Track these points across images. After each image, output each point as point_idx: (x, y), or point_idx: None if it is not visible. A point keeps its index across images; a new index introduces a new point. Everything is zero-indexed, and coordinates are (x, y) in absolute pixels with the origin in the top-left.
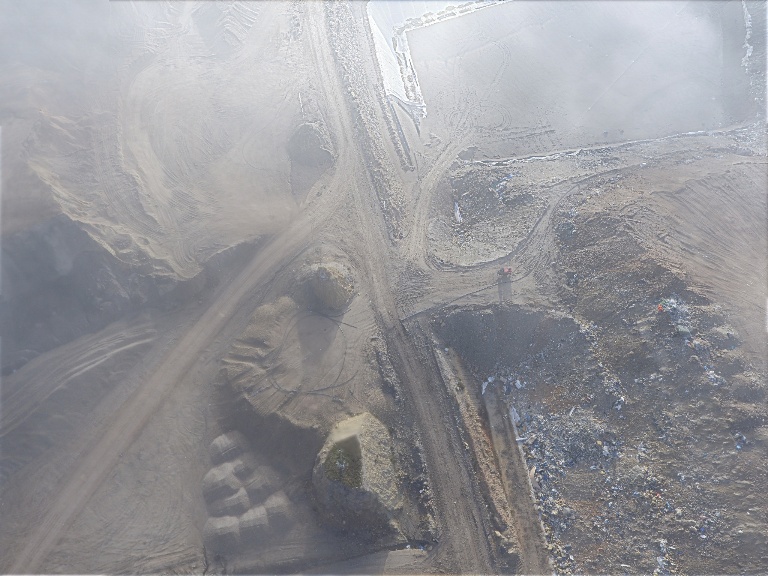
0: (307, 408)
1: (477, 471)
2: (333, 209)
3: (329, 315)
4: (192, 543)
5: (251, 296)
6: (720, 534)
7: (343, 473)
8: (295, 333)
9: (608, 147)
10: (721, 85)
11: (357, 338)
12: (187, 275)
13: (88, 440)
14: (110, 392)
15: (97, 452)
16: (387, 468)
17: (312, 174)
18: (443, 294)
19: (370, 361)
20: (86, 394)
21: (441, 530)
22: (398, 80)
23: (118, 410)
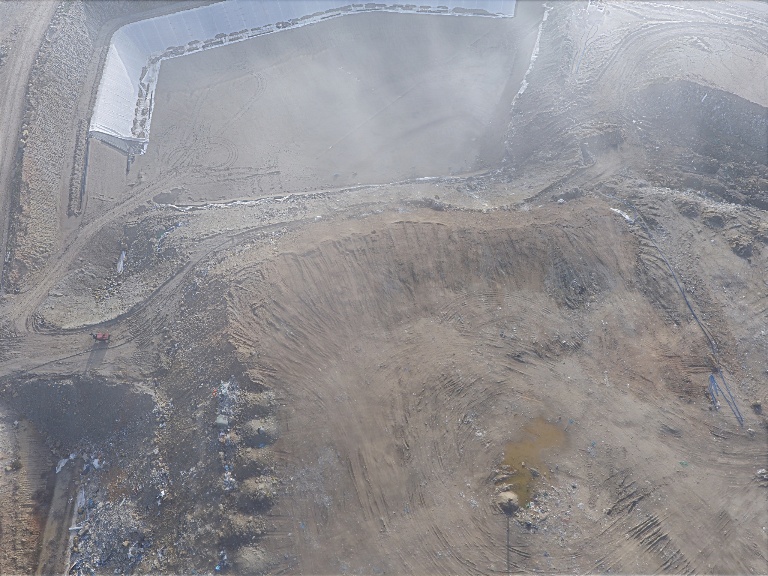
0: None
1: None
2: None
3: None
4: None
5: None
6: None
7: None
8: None
9: (324, 192)
10: (488, 124)
11: None
12: None
13: None
14: None
15: None
16: None
17: None
18: (26, 360)
19: None
20: None
21: None
22: (125, 114)
23: None
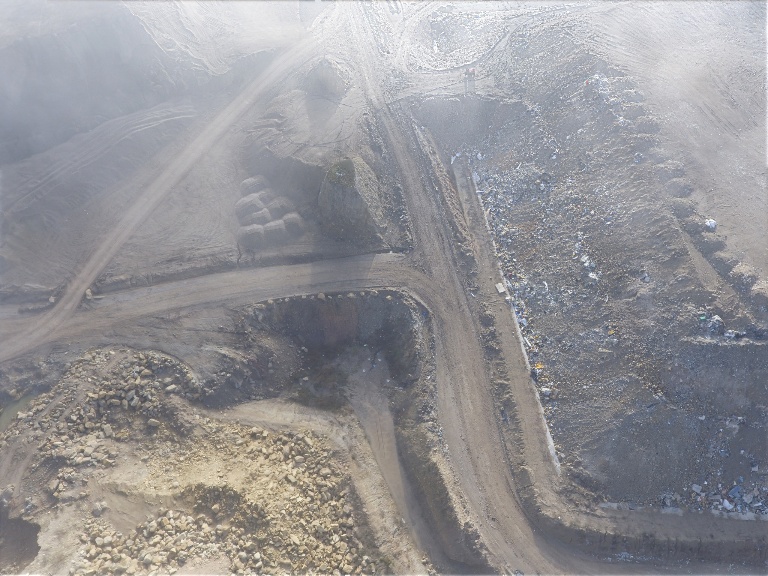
0: (314, 154)
1: (444, 205)
2: (334, 32)
3: (331, 99)
4: (229, 241)
5: (269, 90)
6: (620, 218)
7: (341, 179)
8: (304, 109)
9: None
10: None
11: (352, 113)
12: (219, 72)
13: (148, 177)
14: (163, 148)
15: (155, 185)
16: (375, 197)
17: (316, 8)
18: (420, 87)
19: (362, 127)
20: (145, 146)
21: (416, 241)
22: None
23: (169, 160)
